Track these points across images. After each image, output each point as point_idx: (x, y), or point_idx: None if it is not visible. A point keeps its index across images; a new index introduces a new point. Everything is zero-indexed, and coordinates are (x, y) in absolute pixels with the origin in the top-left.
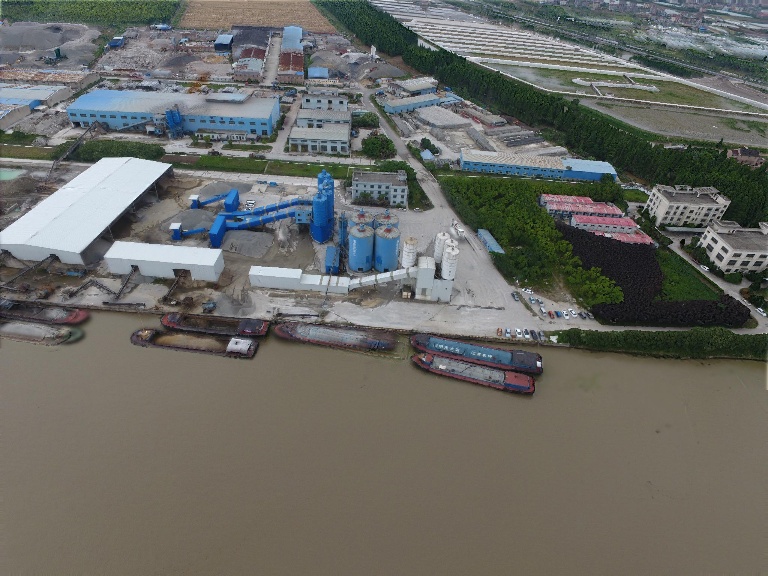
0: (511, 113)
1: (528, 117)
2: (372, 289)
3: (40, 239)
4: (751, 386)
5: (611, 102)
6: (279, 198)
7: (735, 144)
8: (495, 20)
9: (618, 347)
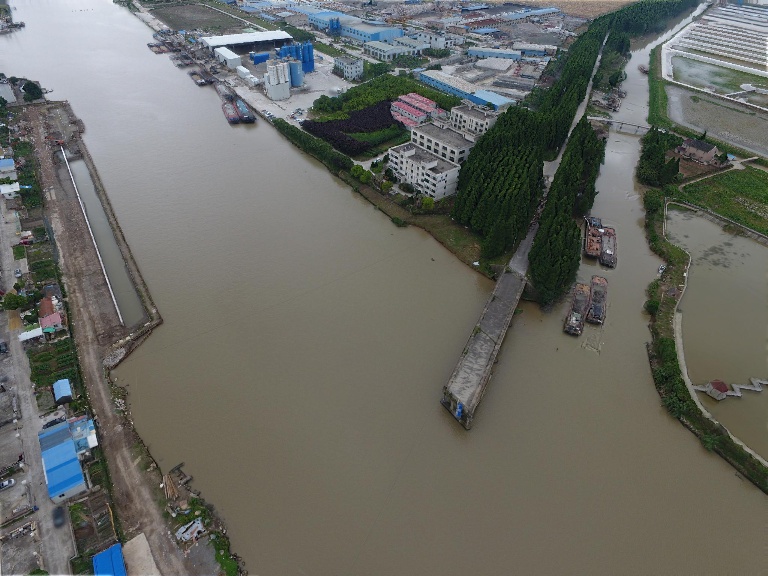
0: None
1: None
2: None
3: None
4: None
5: (719, 101)
6: None
7: (750, 153)
8: None
9: (285, 132)
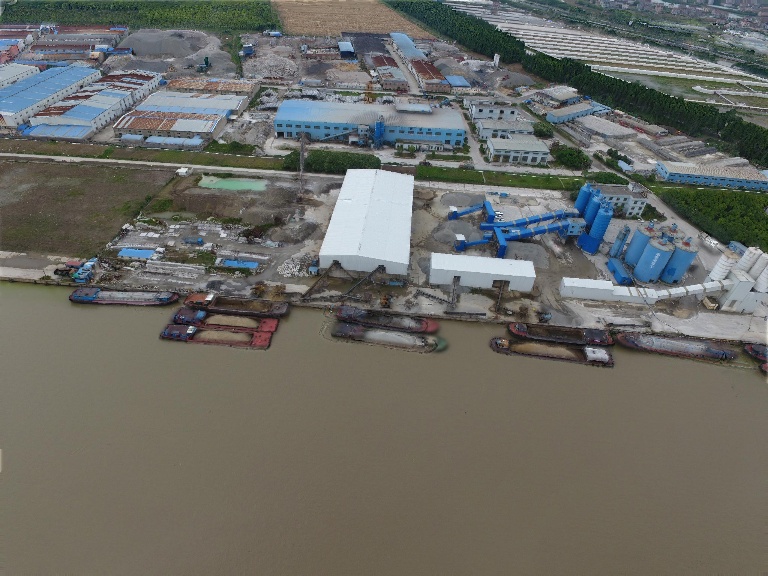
0: (665, 123)
1: (688, 127)
2: (674, 300)
3: (367, 250)
4: None
5: (747, 111)
6: (518, 209)
7: None
8: (573, 25)
9: None
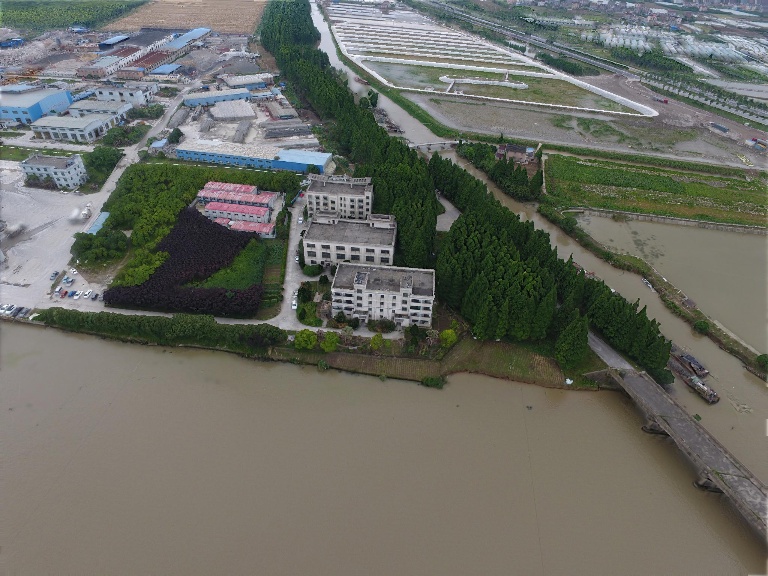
0: (315, 107)
1: (321, 111)
2: None
3: None
4: (182, 376)
5: (450, 98)
6: None
7: (532, 141)
8: (441, 21)
9: (88, 328)
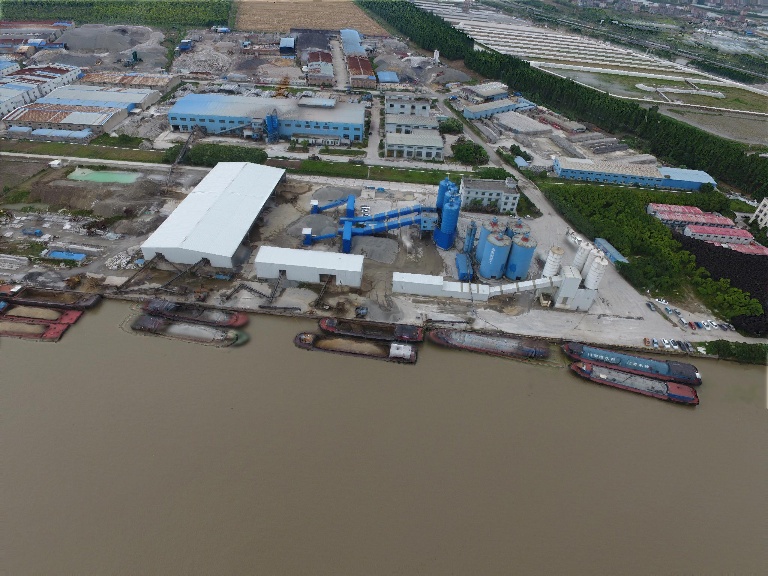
0: (588, 119)
1: (607, 124)
2: (510, 297)
3: (192, 243)
4: None
5: (682, 109)
6: (390, 204)
7: None
8: (540, 23)
9: (767, 360)
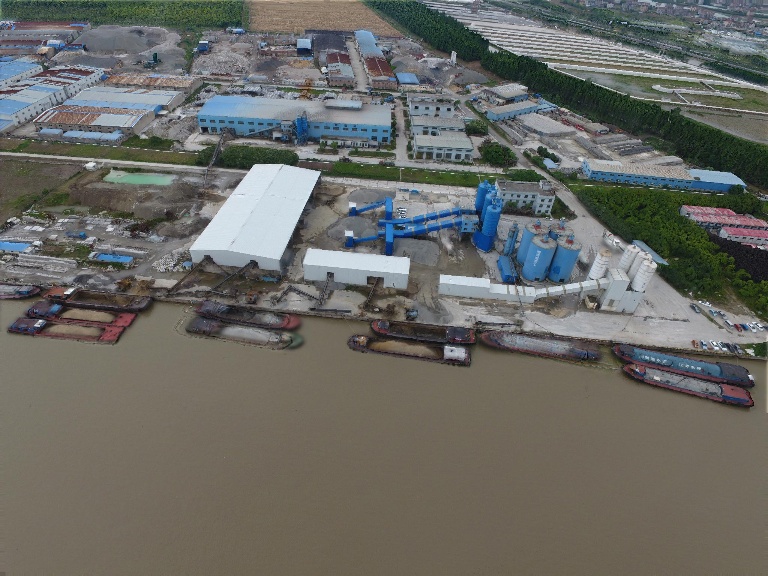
0: (610, 121)
1: (630, 125)
2: (555, 299)
3: (240, 246)
4: None
5: (700, 110)
6: (426, 206)
7: None
8: (550, 24)
9: None
